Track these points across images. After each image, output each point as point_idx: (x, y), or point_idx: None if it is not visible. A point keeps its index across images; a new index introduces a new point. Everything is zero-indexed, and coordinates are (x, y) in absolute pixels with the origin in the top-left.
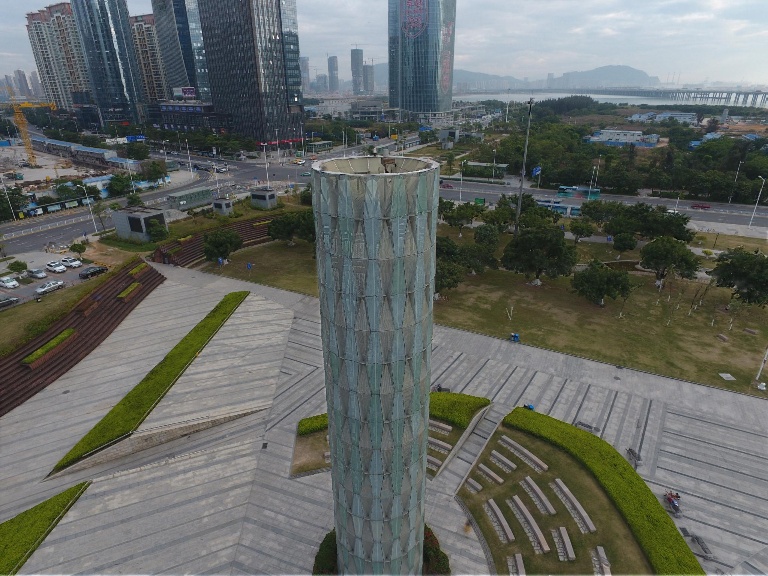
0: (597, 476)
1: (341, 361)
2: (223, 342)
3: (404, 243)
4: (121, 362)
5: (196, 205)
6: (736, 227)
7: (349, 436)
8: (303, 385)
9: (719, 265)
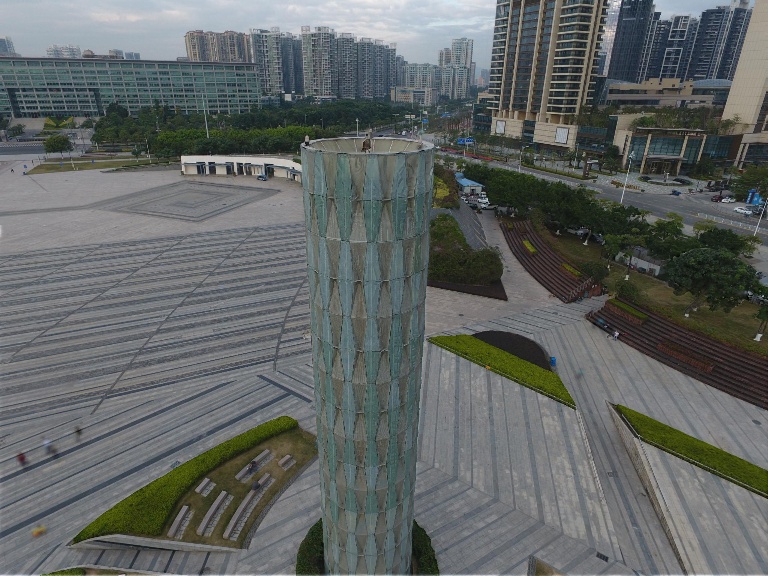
0: None
1: None
2: None
3: None
4: None
5: None
6: None
7: None
8: None
9: None
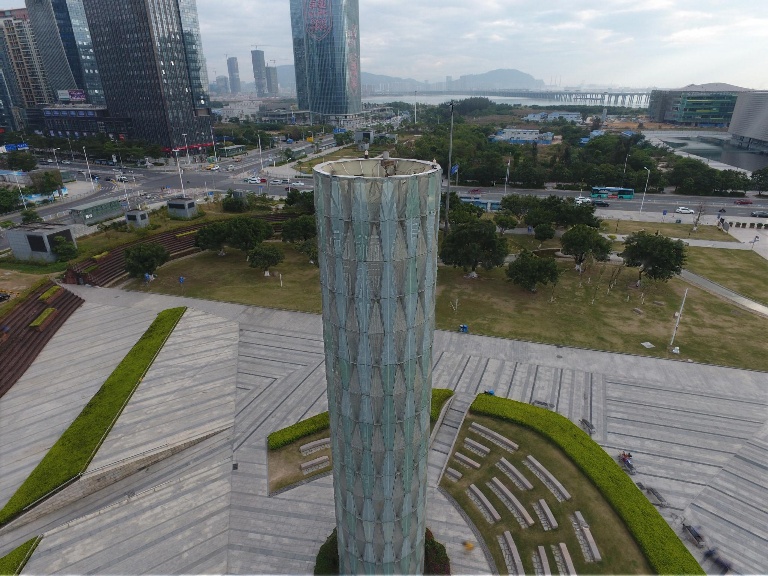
0: (563, 448)
1: (352, 366)
2: (167, 363)
3: (416, 243)
4: (48, 398)
5: (104, 218)
6: (630, 213)
7: (360, 441)
8: (264, 398)
9: (628, 247)
